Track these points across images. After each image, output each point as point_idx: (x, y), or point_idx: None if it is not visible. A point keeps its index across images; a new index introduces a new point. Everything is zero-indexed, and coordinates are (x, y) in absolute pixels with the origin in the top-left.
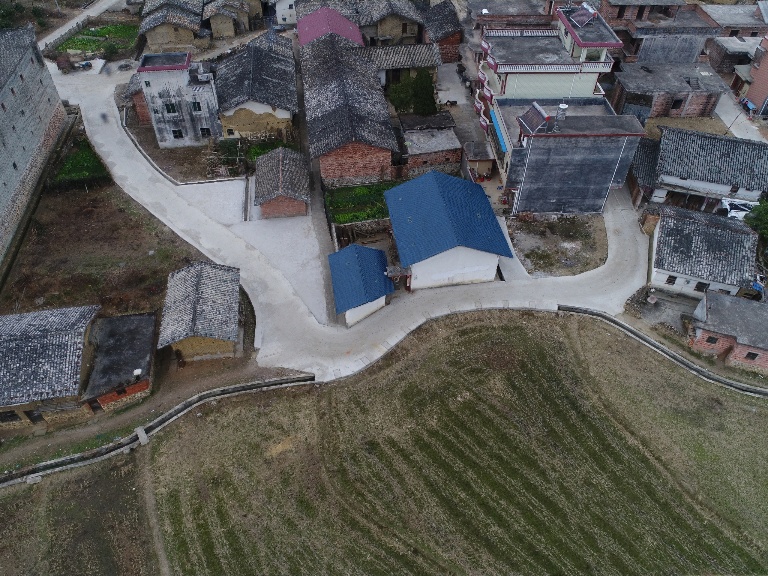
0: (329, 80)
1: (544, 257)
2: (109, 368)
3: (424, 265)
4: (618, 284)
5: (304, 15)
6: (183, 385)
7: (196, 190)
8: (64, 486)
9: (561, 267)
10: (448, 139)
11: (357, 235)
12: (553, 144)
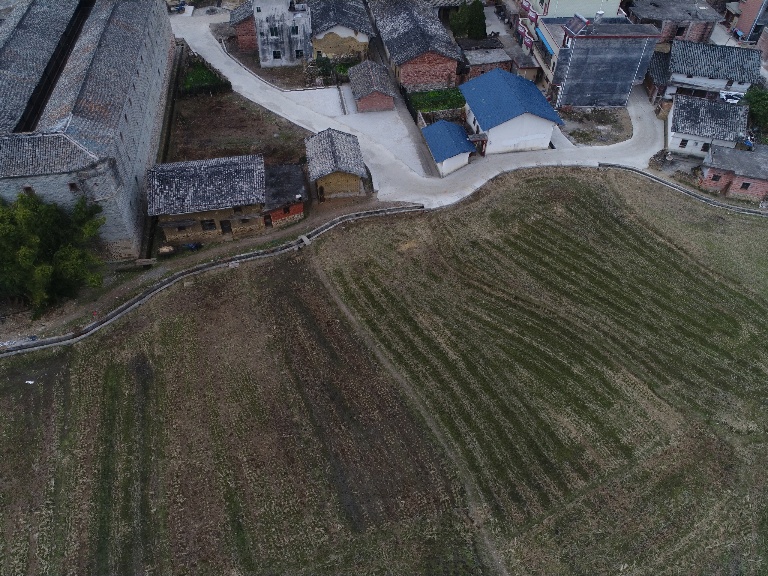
0: (398, 12)
1: (584, 135)
2: (277, 194)
3: (498, 131)
4: (643, 150)
5: None
6: (326, 212)
7: (300, 95)
8: (256, 269)
9: (598, 141)
10: (500, 54)
11: (436, 121)
12: (591, 45)
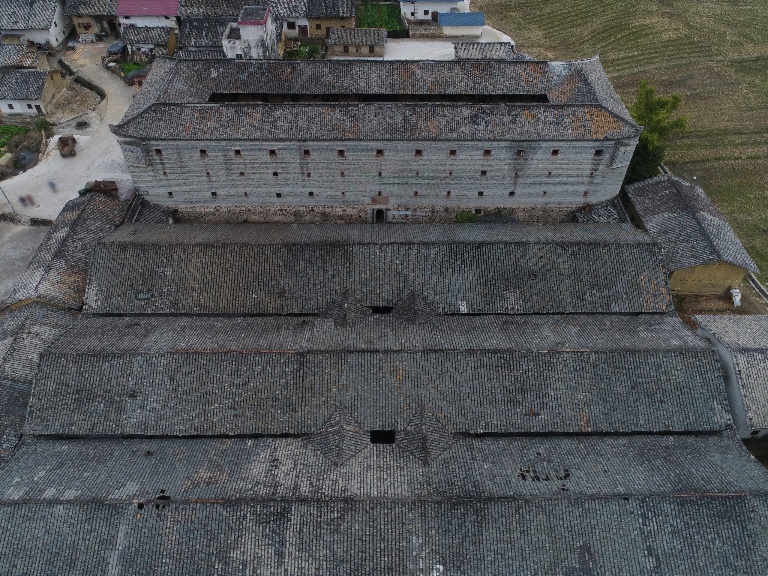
0: None
1: None
2: None
3: None
4: None
5: (113, 8)
6: None
7: None
8: None
9: None
10: None
11: None
12: None
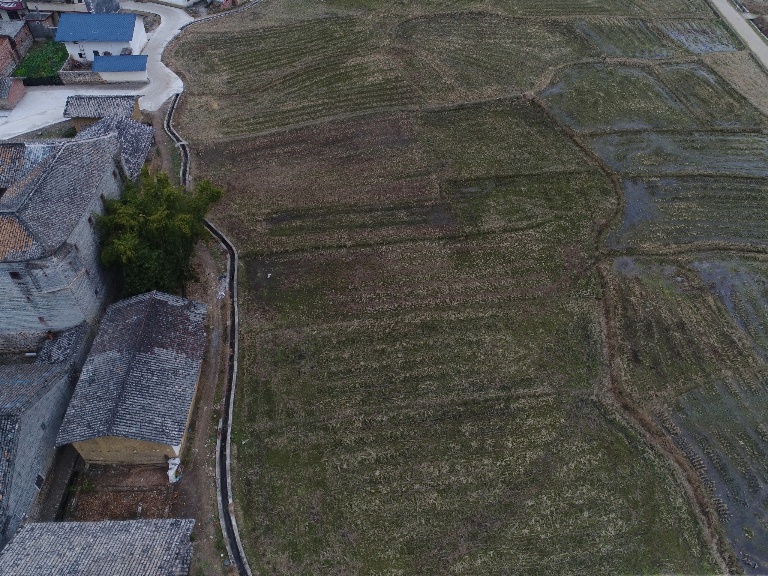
0: None
1: None
2: None
3: None
4: (176, 15)
5: None
6: None
7: None
8: None
9: (151, 26)
10: (10, 24)
11: None
12: None
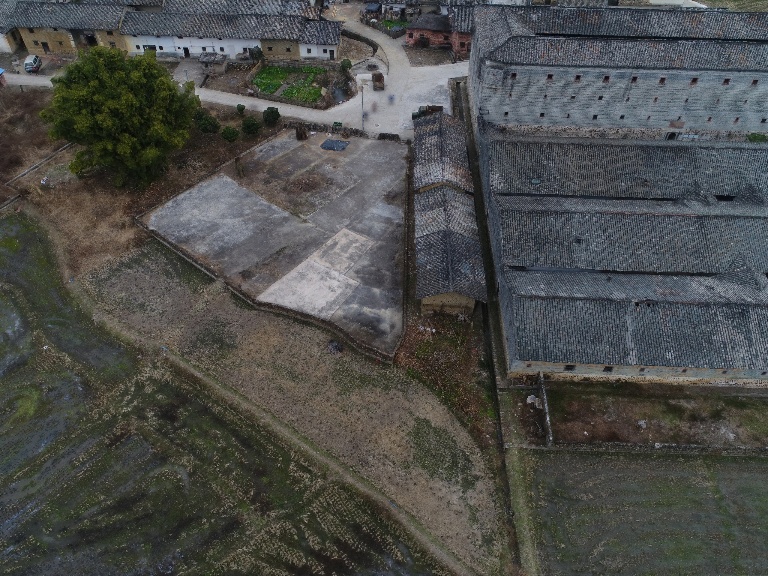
0: None
1: None
2: None
3: None
4: None
5: None
6: None
7: None
8: None
9: None
10: None
11: None
12: None
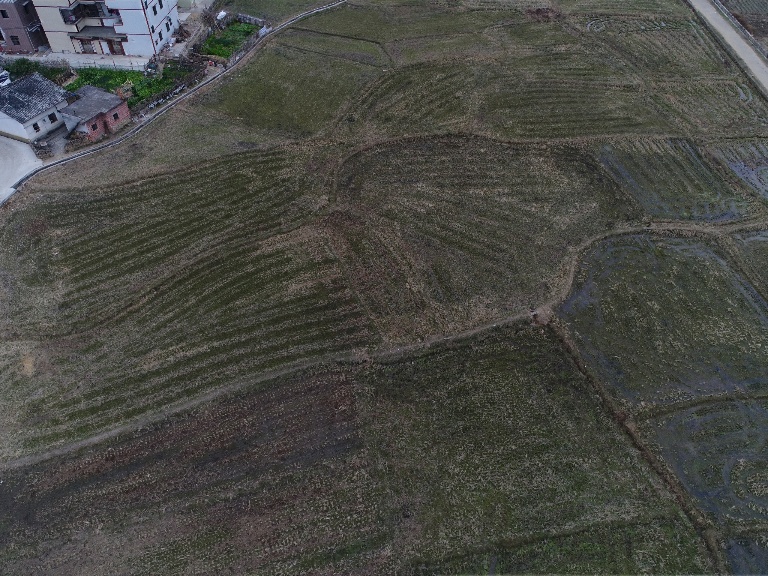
0: None
1: None
2: None
3: None
4: (17, 156)
5: None
6: None
7: None
8: None
9: None
10: None
11: None
12: None
